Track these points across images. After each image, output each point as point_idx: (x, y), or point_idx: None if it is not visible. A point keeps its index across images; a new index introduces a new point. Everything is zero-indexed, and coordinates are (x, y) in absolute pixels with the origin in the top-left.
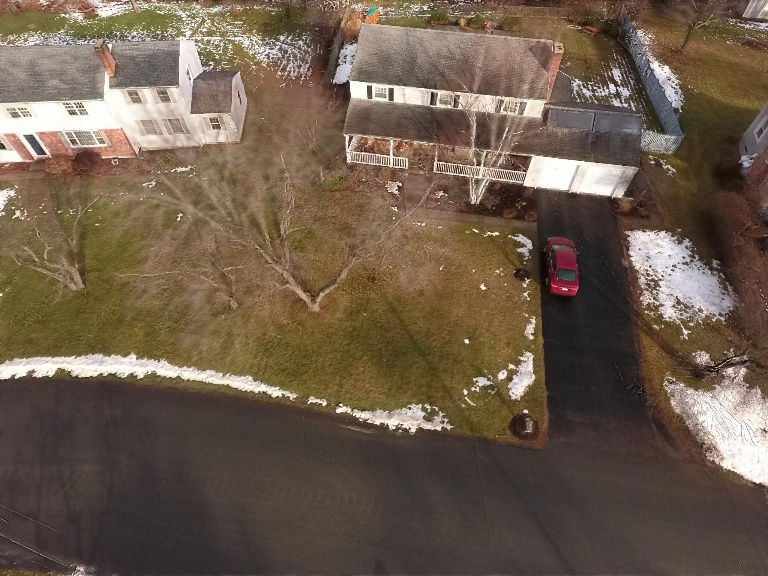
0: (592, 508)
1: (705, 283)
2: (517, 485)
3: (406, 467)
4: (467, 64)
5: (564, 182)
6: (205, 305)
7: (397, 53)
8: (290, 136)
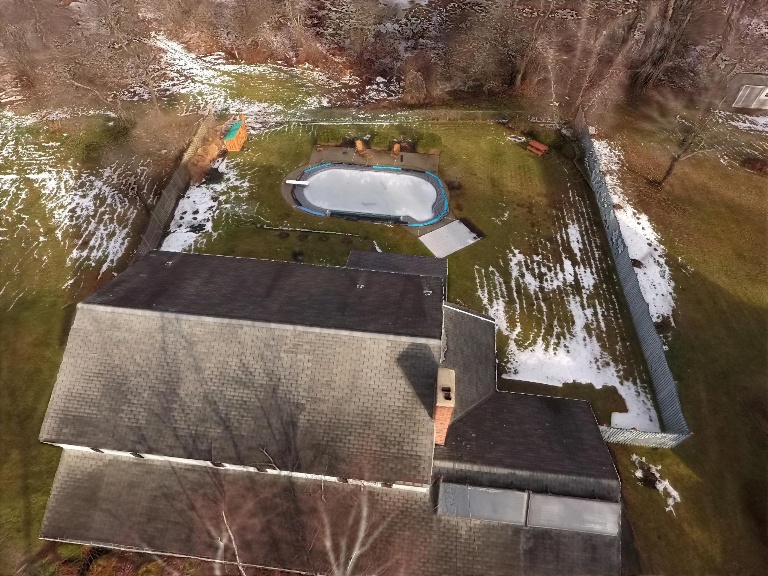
0: None
1: None
2: None
3: None
4: (275, 397)
5: None
6: None
7: (140, 372)
8: (27, 431)
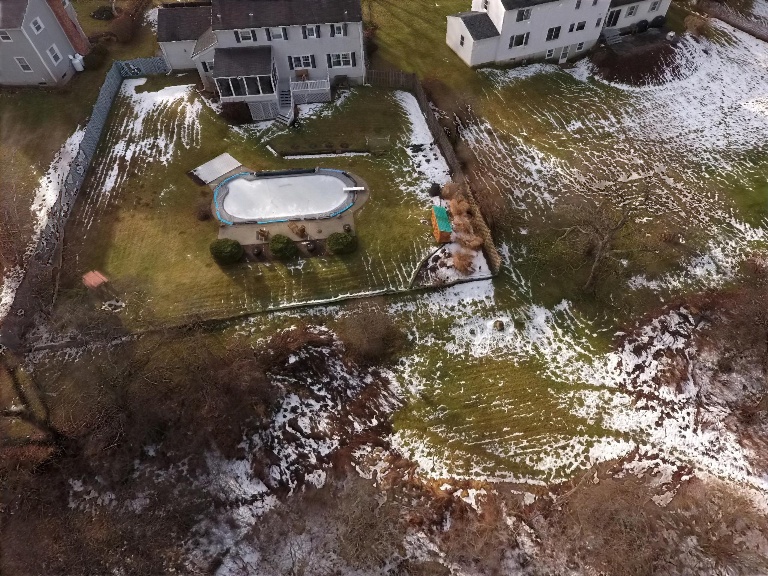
0: None
1: None
2: None
3: None
4: None
5: None
6: None
7: None
8: (416, 54)
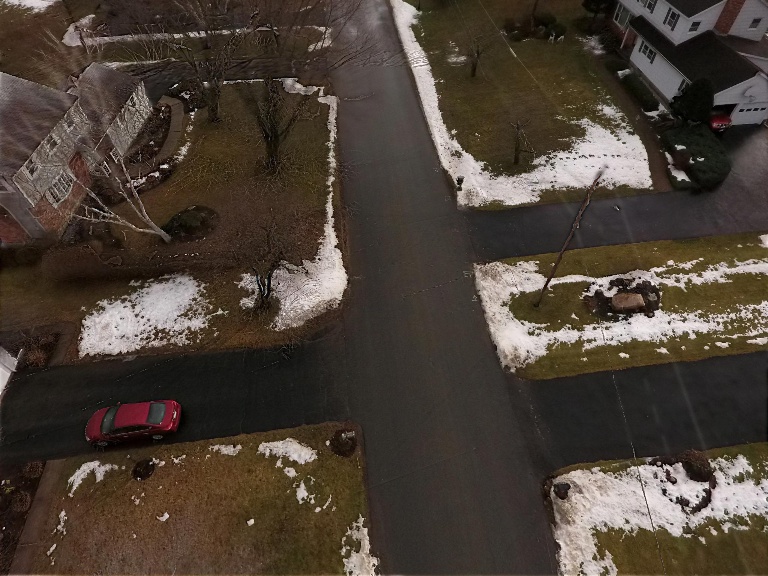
0: (398, 383)
1: (161, 293)
2: (399, 442)
3: (415, 556)
4: None
5: None
6: None
7: None
8: None
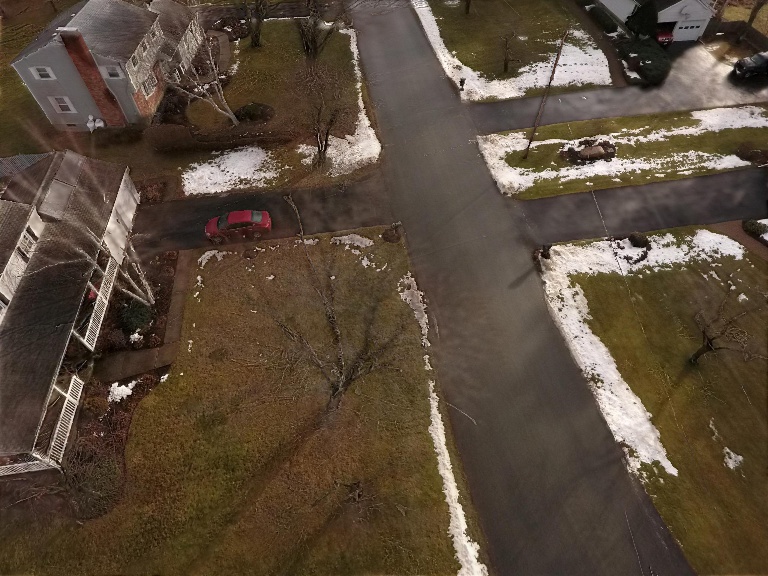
0: (427, 203)
1: (238, 158)
2: (431, 234)
3: (449, 290)
4: None
5: (121, 231)
6: (365, 532)
7: None
8: None
